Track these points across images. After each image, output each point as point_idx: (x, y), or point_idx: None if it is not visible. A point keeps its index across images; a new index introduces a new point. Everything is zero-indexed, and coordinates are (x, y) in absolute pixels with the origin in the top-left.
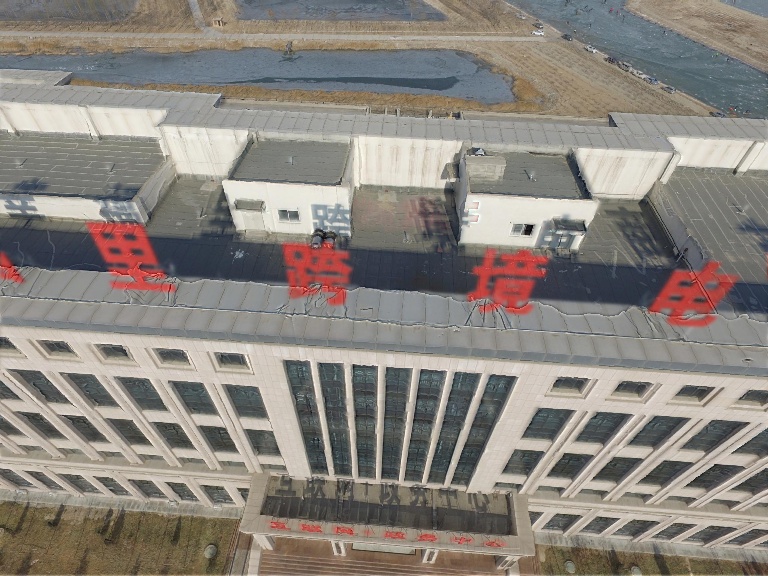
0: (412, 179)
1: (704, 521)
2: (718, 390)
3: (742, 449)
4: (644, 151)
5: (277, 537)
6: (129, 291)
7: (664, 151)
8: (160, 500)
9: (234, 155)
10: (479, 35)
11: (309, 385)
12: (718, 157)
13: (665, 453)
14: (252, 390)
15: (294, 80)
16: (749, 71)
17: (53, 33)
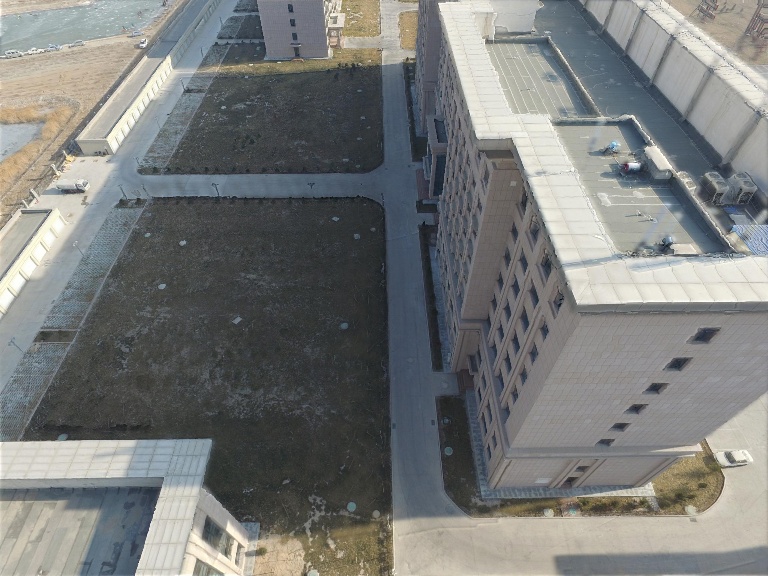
0: None
1: None
2: None
3: None
4: None
5: None
6: None
7: None
8: None
9: None
10: None
11: None
12: None
13: None
14: None
15: None
16: (61, 12)
17: None
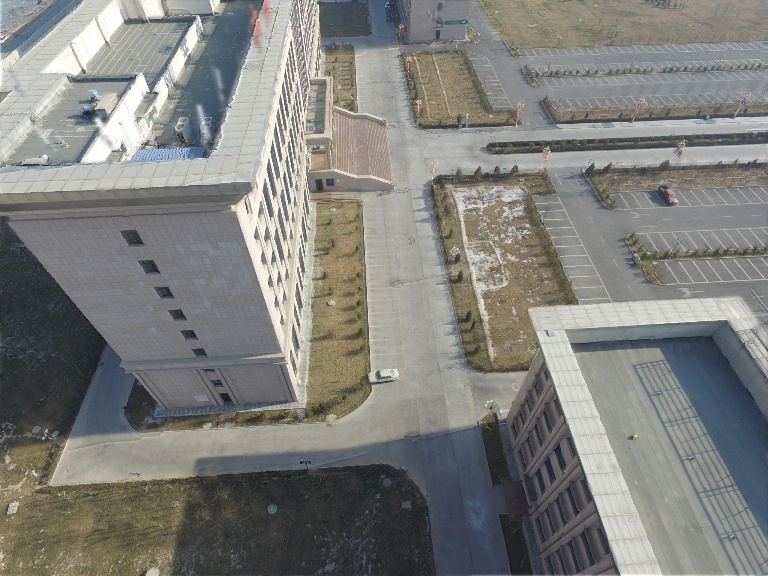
0: None
1: None
2: None
3: None
4: None
5: None
6: None
7: None
8: None
9: (156, 2)
10: None
11: None
12: None
13: None
14: None
15: None
16: None
17: None
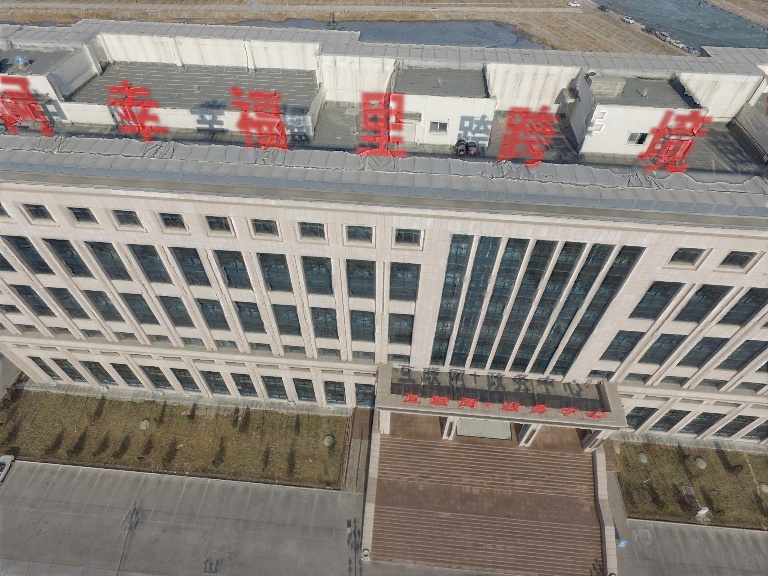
0: (529, 104)
1: (766, 412)
2: None
3: None
4: (738, 75)
5: (391, 425)
6: (369, 158)
7: (756, 75)
8: (279, 401)
9: (378, 82)
10: (516, 6)
11: (463, 263)
12: None
13: (750, 330)
14: (410, 271)
15: None
16: None
17: (104, 5)
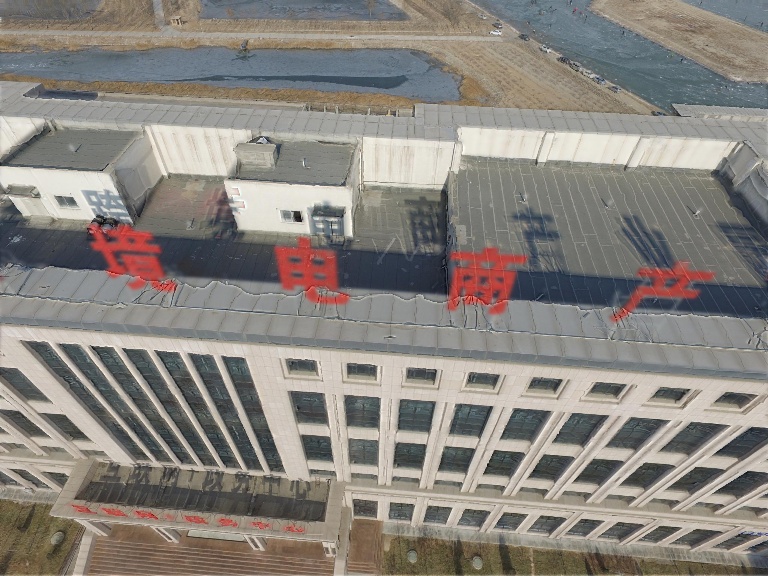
0: (217, 168)
1: (530, 510)
2: (440, 372)
3: (514, 435)
4: (427, 140)
5: (115, 524)
6: None
7: (446, 140)
8: (17, 488)
9: None
10: (436, 35)
11: None
12: (517, 148)
13: (439, 438)
14: None
15: (243, 78)
16: (701, 71)
17: (11, 31)
